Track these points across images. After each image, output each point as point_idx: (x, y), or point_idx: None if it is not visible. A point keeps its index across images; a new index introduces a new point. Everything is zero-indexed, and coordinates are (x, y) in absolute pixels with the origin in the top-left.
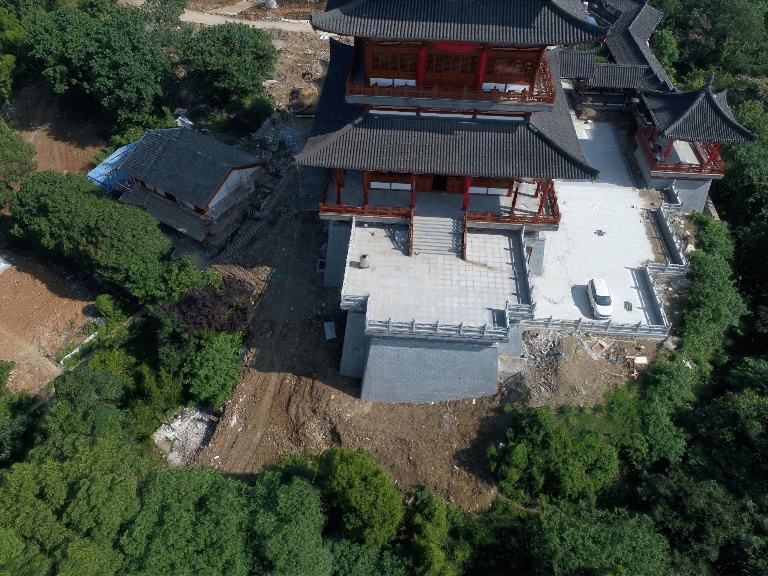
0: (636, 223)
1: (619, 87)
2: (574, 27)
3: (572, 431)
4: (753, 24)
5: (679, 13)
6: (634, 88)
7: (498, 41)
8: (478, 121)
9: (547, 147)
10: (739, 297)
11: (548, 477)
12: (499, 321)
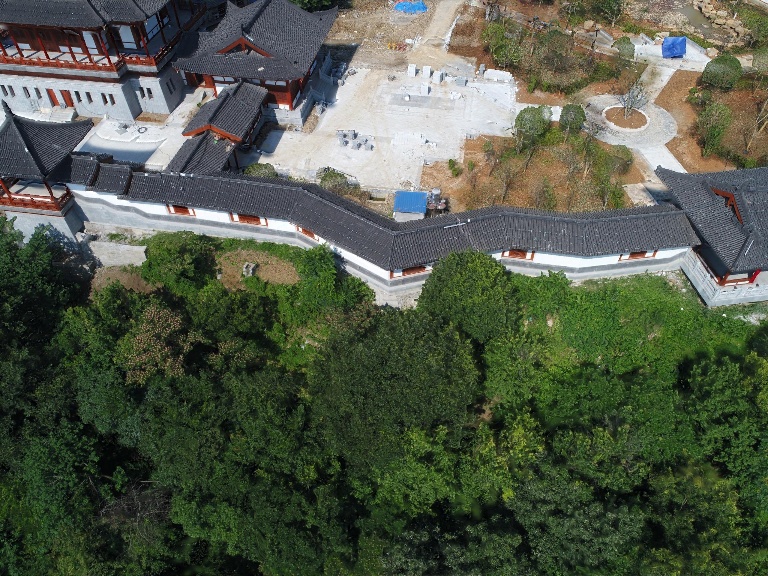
0: None
1: None
2: None
3: None
4: (338, 400)
5: None
6: None
7: None
8: None
9: None
10: None
11: None
12: None
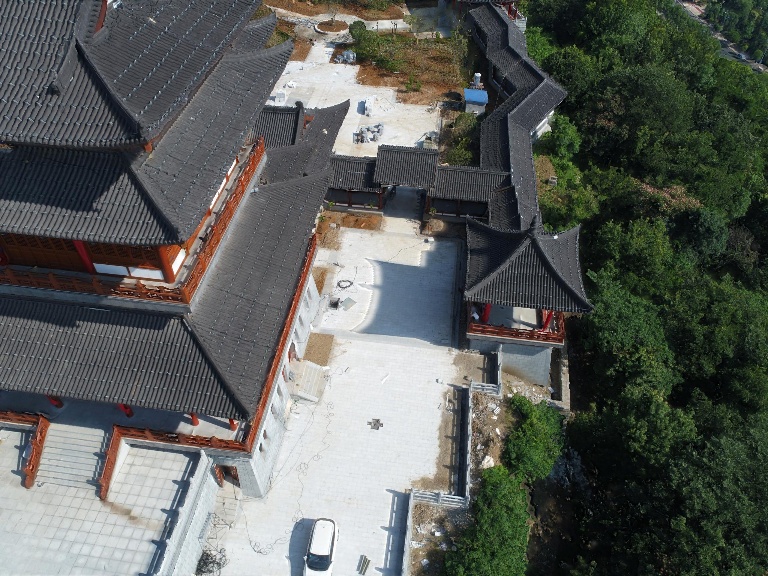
0: (432, 409)
1: (467, 199)
2: (151, 215)
3: None
4: (677, 110)
5: (593, 90)
6: (486, 201)
7: (26, 233)
8: (112, 308)
9: (200, 357)
10: (523, 565)
11: None
12: None
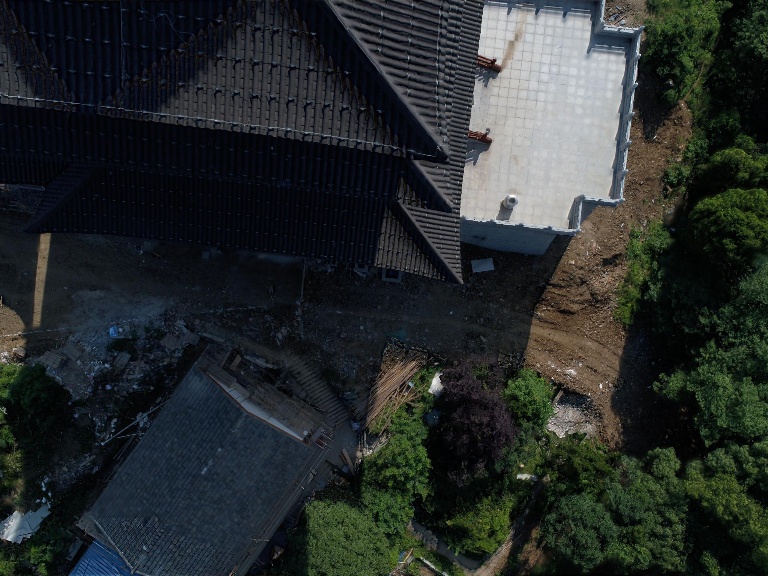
0: None
1: None
2: None
3: (676, 3)
4: None
5: None
6: None
7: None
8: None
9: None
10: None
11: (700, 44)
12: (609, 42)
